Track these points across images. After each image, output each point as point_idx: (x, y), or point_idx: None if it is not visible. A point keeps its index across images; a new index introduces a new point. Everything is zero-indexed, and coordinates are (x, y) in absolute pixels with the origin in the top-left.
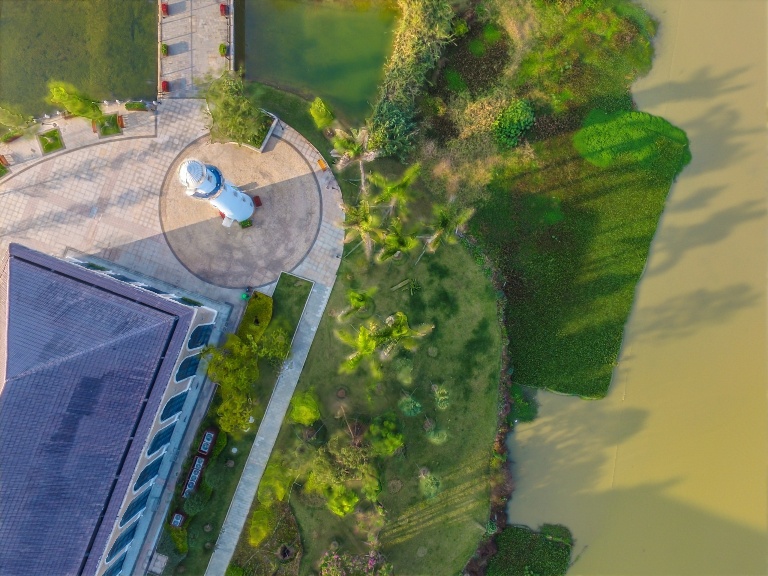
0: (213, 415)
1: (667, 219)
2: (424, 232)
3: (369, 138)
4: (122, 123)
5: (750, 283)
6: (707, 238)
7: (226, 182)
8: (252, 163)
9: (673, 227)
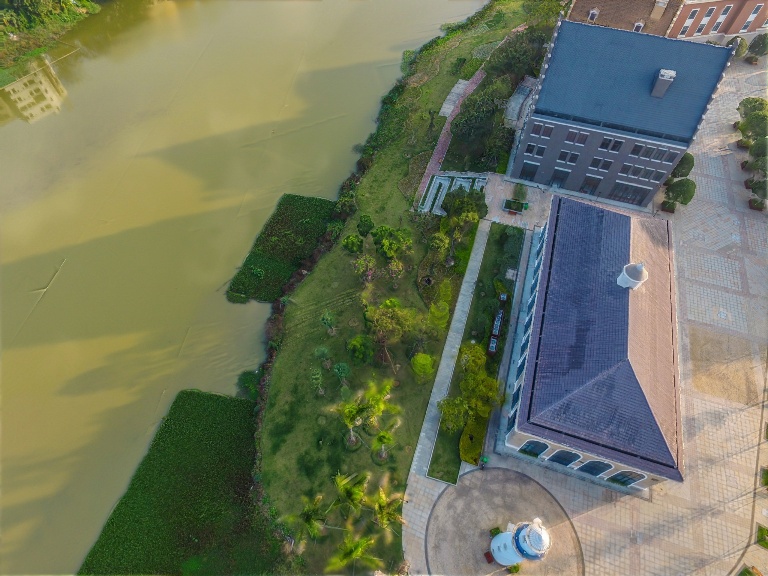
0: (493, 365)
1: (72, 569)
2: (325, 538)
3: None
4: None
5: (11, 500)
6: (37, 548)
7: None
8: None
9: (69, 559)
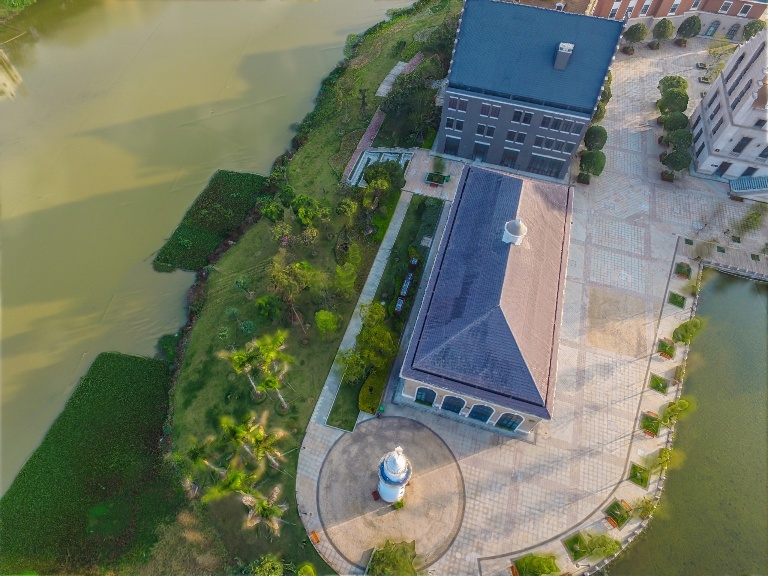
0: (399, 324)
1: None
2: None
3: (268, 575)
4: (513, 571)
5: None
6: None
7: (407, 514)
8: (383, 536)
9: None
